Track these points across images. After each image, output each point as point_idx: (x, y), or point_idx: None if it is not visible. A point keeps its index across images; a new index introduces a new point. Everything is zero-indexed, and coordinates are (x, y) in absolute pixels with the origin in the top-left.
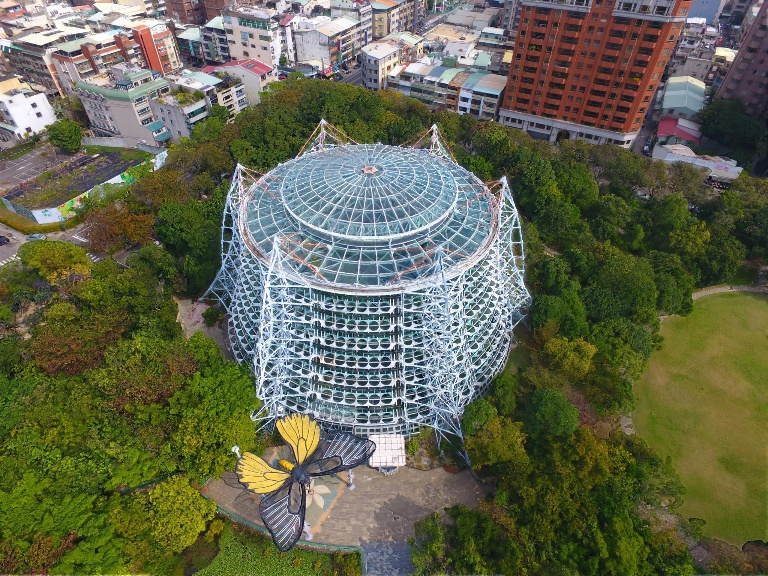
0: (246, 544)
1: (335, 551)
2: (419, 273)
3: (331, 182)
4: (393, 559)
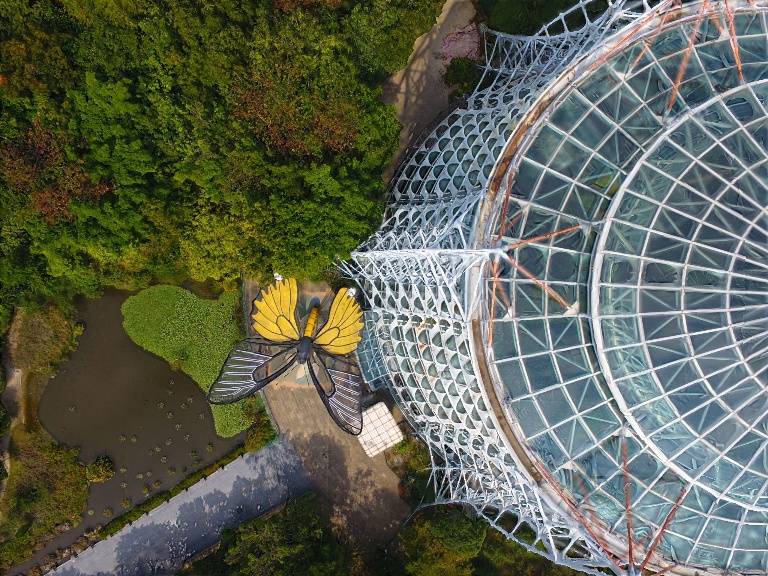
0: (234, 320)
1: (267, 412)
2: (590, 496)
3: (762, 231)
4: (289, 468)
